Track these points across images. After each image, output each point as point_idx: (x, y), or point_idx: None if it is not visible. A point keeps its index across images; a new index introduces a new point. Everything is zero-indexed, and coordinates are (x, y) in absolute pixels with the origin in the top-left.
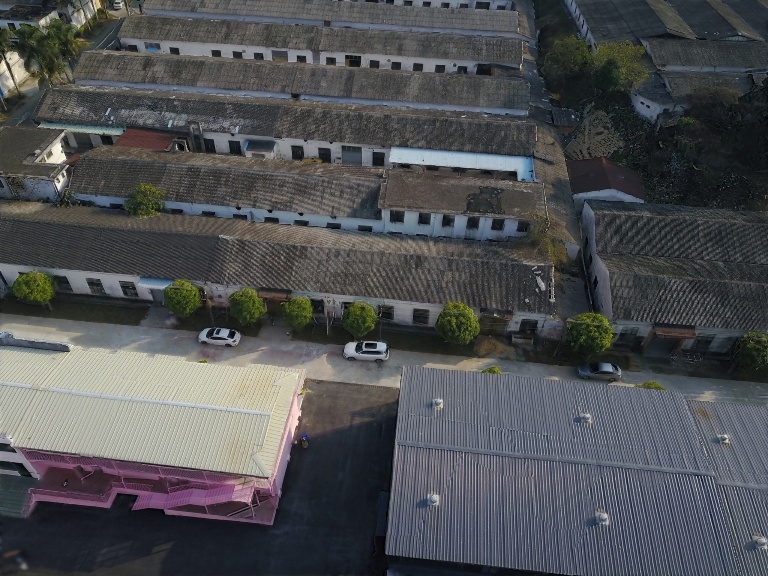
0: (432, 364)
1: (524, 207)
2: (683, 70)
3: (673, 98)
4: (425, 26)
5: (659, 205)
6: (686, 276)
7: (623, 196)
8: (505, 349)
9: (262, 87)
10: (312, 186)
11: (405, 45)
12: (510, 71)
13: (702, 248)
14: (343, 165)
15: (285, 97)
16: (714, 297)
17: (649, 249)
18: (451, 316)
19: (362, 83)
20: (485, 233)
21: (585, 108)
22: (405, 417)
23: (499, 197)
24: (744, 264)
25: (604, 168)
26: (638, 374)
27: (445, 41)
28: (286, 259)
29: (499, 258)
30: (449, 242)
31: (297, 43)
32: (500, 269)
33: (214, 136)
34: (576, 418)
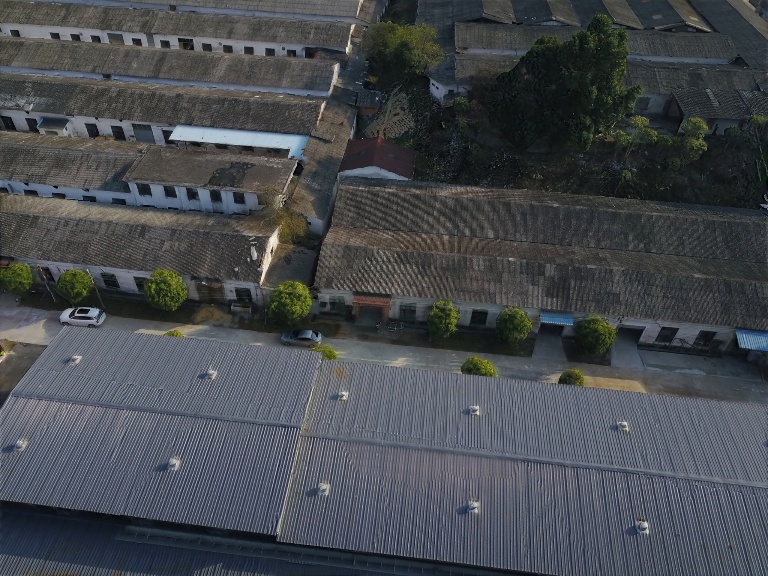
0: (144, 330)
1: (265, 181)
2: (483, 53)
3: (456, 79)
4: (267, 11)
5: (415, 182)
6: (396, 247)
7: (387, 173)
8: (222, 317)
9: (74, 67)
10: (71, 160)
11: (236, 29)
12: (335, 55)
13: (434, 222)
14: (118, 141)
15: (97, 77)
16: (416, 267)
17: (383, 223)
18: (152, 282)
19: (172, 64)
20: (230, 207)
21: (393, 90)
22: (35, 371)
23: (246, 172)
24: (470, 238)
25: (376, 147)
26: (342, 341)
27: (276, 25)
28: (16, 228)
29: (223, 229)
30: (189, 214)
31: (131, 26)
32: (219, 239)
33: (10, 114)
34: (202, 374)
